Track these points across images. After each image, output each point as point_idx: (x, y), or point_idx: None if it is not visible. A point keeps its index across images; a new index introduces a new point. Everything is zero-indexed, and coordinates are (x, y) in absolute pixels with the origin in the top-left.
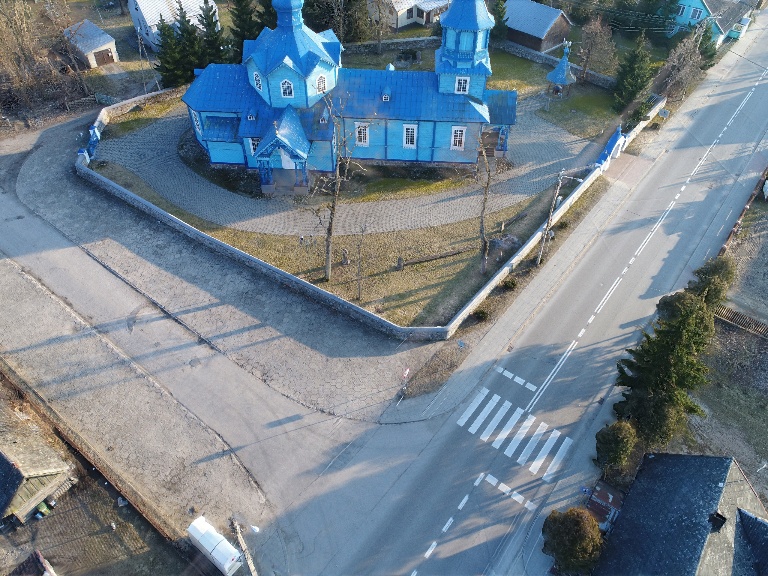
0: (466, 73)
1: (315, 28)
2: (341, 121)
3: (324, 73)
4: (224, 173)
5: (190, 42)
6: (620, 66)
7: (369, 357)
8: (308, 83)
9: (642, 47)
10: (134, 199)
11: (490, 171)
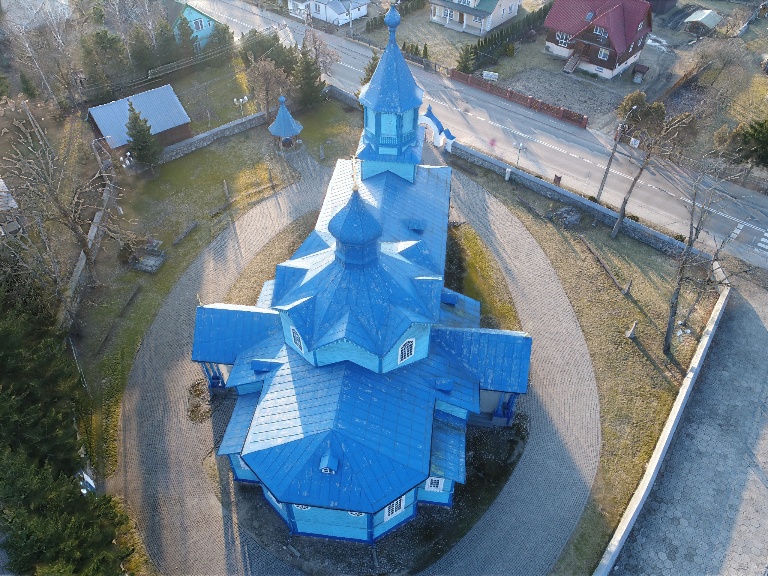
0: None
1: None
2: None
3: None
4: (465, 486)
5: None
6: (305, 83)
7: (760, 317)
8: None
9: (199, 78)
10: None
11: None
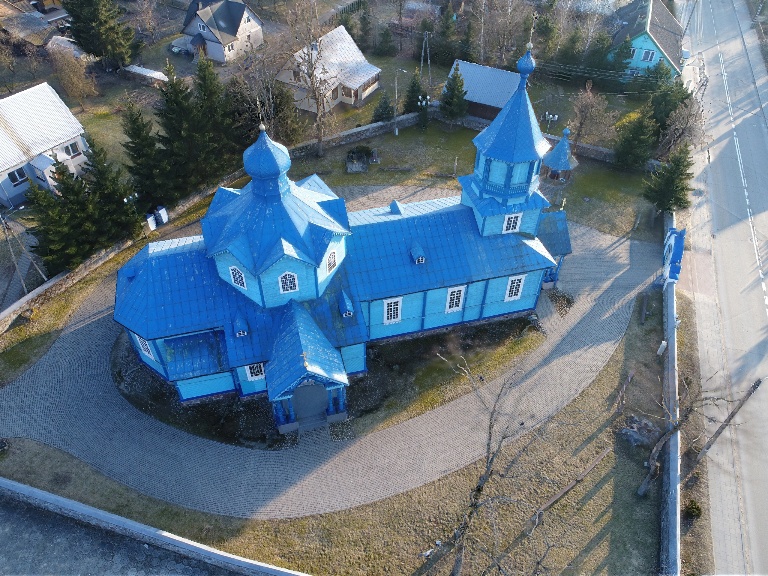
0: (520, 210)
1: (235, 140)
2: (365, 303)
3: (334, 247)
4: (207, 411)
5: (78, 203)
6: (625, 139)
7: None
8: (318, 268)
9: None
10: (89, 516)
11: (552, 314)
